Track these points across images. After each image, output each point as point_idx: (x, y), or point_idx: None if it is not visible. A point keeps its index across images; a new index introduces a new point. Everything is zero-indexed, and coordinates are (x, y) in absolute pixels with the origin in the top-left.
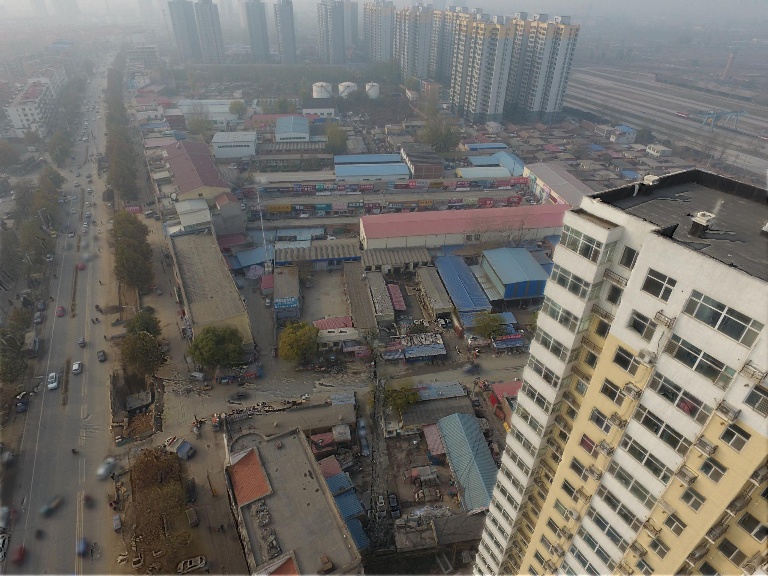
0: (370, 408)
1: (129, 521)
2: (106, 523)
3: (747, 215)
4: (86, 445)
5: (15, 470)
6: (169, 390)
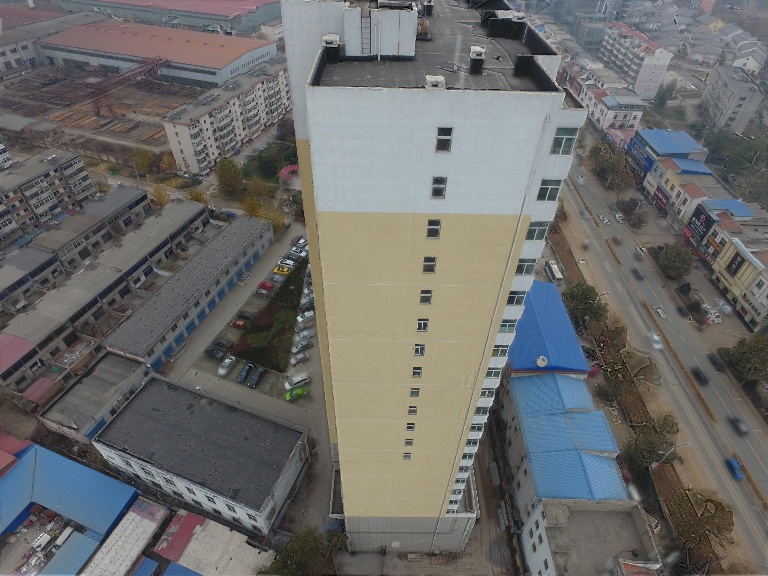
0: None
1: None
2: None
3: (375, 70)
4: None
5: None
6: None
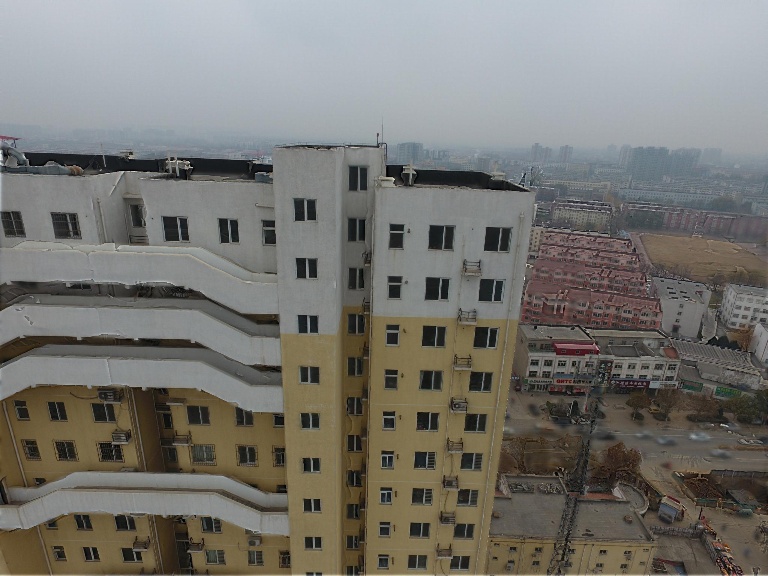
0: None
1: (567, 437)
2: (592, 463)
3: None
4: (673, 459)
5: (644, 427)
6: (764, 518)
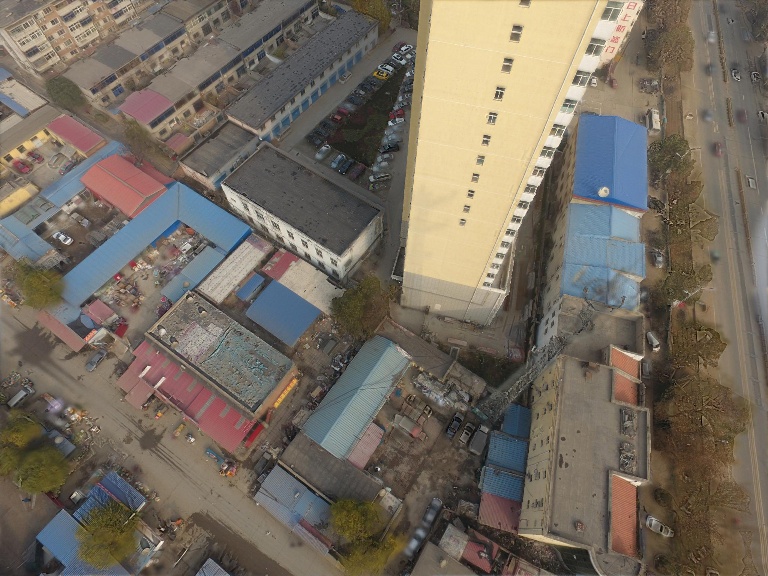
0: (383, 564)
1: None
2: None
3: None
4: None
5: None
6: None
